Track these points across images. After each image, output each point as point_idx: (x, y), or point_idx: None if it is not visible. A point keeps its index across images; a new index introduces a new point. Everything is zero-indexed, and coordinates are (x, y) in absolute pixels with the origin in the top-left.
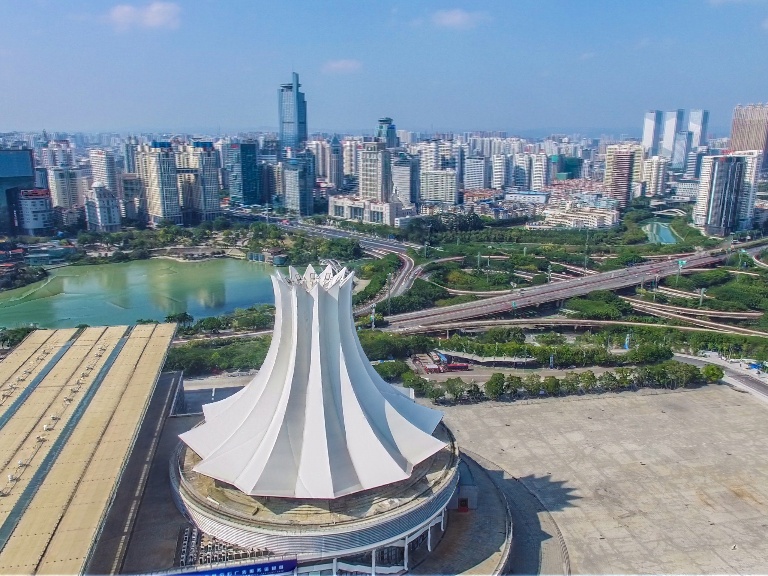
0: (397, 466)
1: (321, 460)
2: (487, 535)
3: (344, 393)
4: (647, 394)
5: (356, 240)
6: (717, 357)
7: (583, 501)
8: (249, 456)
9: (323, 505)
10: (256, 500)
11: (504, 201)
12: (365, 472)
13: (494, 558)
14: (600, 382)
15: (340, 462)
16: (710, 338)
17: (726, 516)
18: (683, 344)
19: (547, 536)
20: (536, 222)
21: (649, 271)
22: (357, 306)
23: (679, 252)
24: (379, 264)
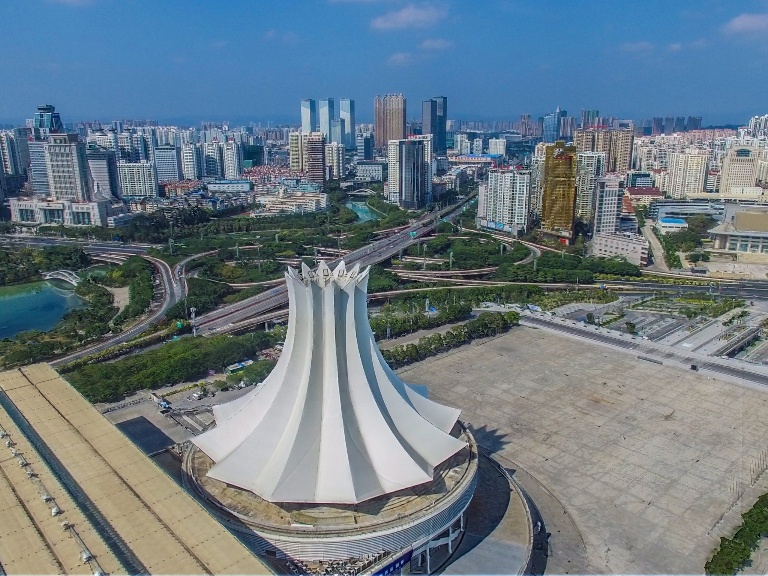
0: (452, 438)
1: (394, 451)
2: (492, 482)
3: (381, 384)
4: (480, 344)
5: (79, 246)
6: (497, 306)
7: (510, 437)
8: (314, 470)
9: (408, 493)
10: (344, 510)
11: (210, 191)
12: (426, 452)
13: (514, 497)
14: (445, 341)
15: (407, 448)
16: (479, 292)
17: (602, 418)
18: (466, 300)
19: (512, 471)
20: (259, 210)
21: (391, 244)
22: (139, 316)
23: (398, 225)
24: (128, 269)
